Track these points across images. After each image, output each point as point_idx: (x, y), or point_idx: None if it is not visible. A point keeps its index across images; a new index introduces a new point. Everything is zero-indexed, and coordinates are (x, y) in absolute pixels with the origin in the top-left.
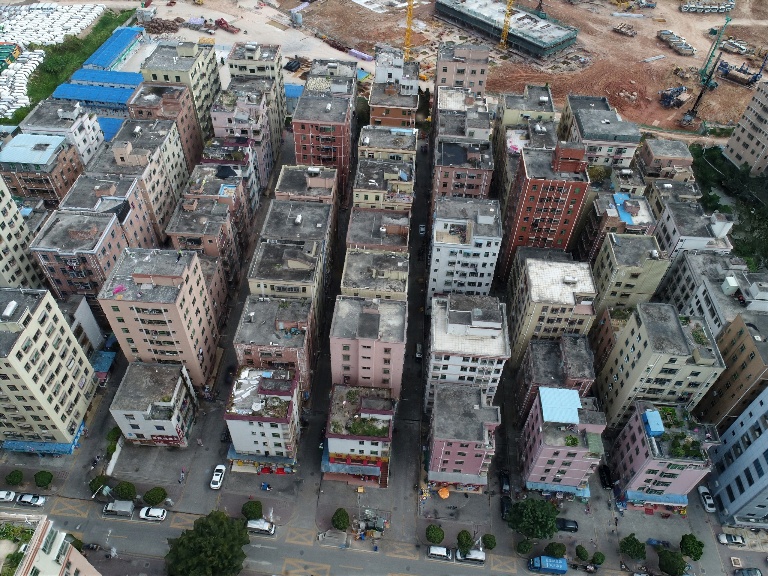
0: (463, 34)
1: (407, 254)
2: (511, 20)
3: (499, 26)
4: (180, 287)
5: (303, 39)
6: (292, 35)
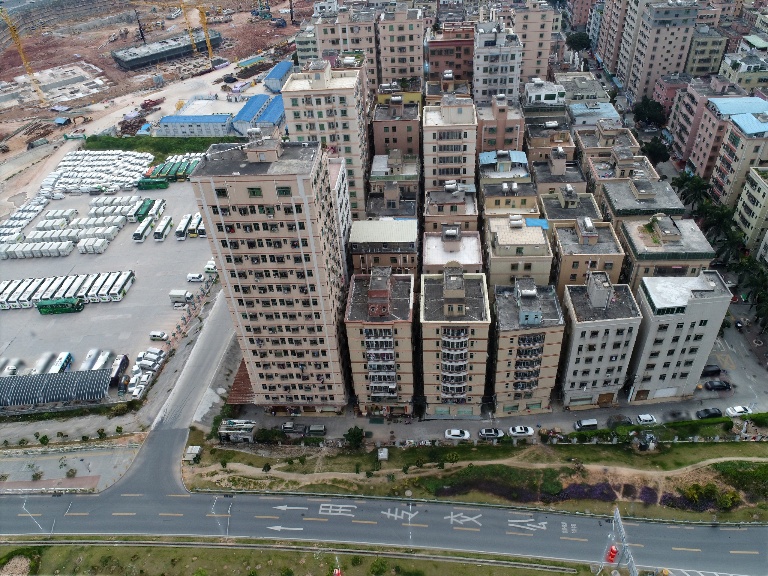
0: (168, 65)
1: (466, 3)
2: (177, 42)
3: (184, 45)
4: (510, 5)
5: (184, 83)
6: (176, 86)
